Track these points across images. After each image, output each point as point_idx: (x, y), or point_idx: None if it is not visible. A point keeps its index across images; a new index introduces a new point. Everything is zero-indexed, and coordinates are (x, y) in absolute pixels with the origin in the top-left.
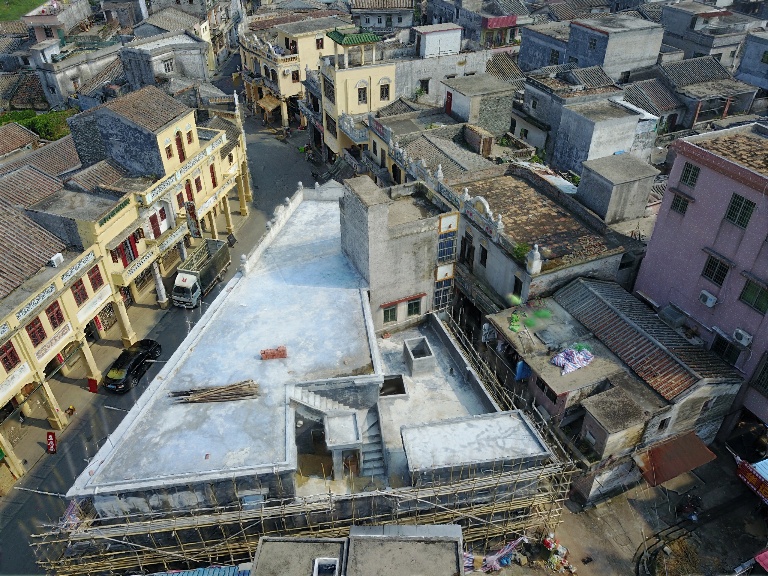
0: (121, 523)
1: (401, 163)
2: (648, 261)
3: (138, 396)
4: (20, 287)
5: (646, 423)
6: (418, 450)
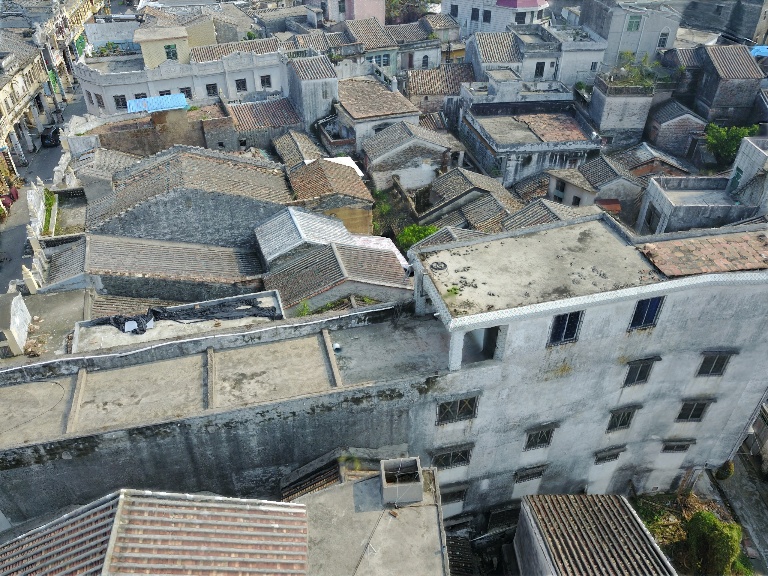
0: None
1: None
2: None
3: None
4: (68, 2)
5: (277, 4)
6: None
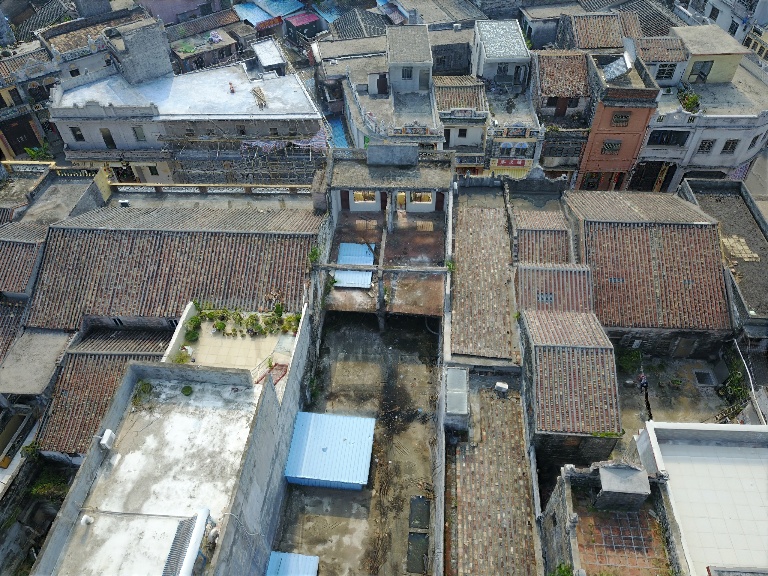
0: (320, 128)
1: (1, 86)
2: (154, 7)
3: None
4: None
5: None
6: (275, 63)
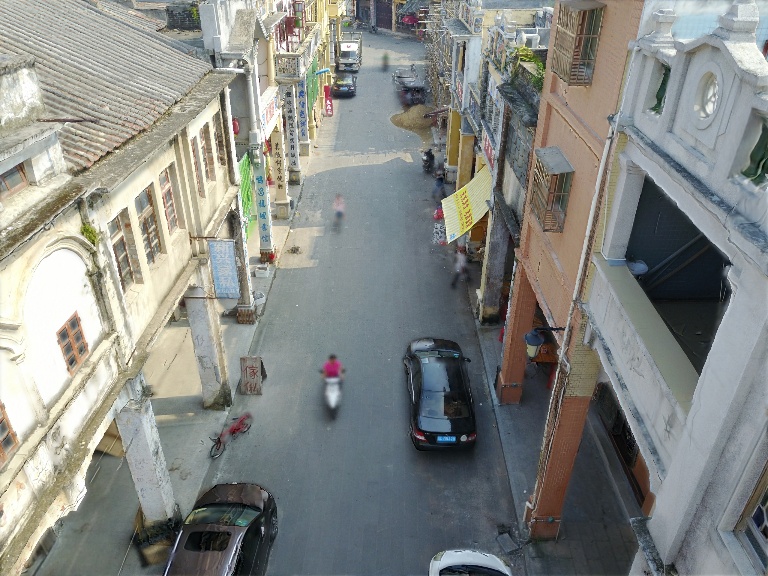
0: None
1: None
2: None
3: (364, 98)
4: None
5: None
6: None
